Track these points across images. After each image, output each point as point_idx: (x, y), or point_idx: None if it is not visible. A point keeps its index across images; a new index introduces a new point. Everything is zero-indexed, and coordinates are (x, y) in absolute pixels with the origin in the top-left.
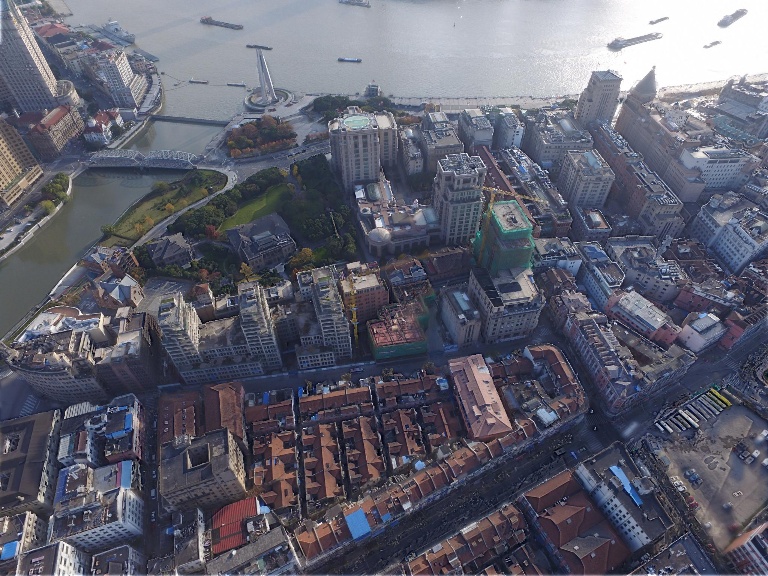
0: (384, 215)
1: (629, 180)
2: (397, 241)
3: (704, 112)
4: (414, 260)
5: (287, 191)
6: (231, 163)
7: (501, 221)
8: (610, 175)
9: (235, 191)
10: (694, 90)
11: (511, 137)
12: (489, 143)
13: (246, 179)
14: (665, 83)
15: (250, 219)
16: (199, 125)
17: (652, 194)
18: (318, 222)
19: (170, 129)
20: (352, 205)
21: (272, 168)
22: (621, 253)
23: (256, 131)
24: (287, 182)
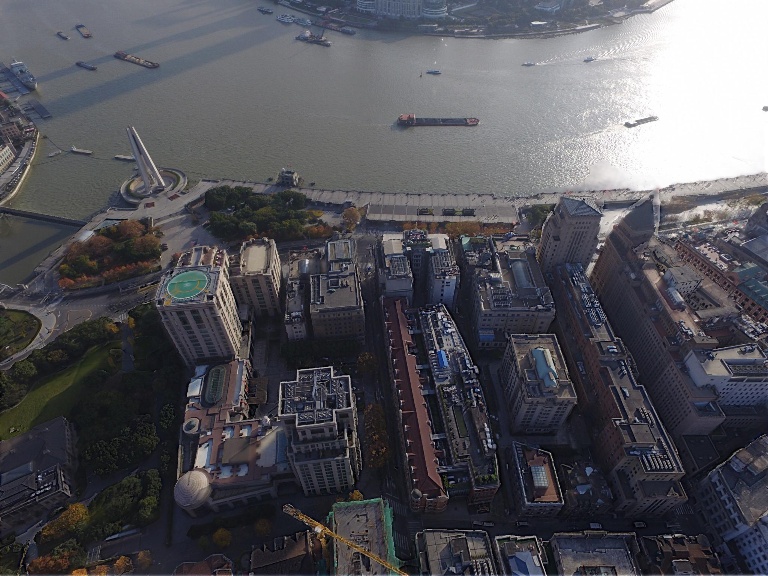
0: (215, 439)
1: (602, 392)
2: (219, 499)
3: (725, 253)
4: (216, 573)
5: (97, 371)
6: (58, 298)
7: (340, 563)
8: (569, 397)
9: (24, 367)
10: (713, 191)
11: (439, 288)
12: (408, 293)
13: (55, 338)
14: (674, 179)
15: (36, 415)
16: (53, 222)
17: (634, 445)
18: (113, 445)
19: (14, 228)
20: (181, 405)
21: (95, 322)
22: (573, 572)
23: (110, 244)
24: (119, 339)
